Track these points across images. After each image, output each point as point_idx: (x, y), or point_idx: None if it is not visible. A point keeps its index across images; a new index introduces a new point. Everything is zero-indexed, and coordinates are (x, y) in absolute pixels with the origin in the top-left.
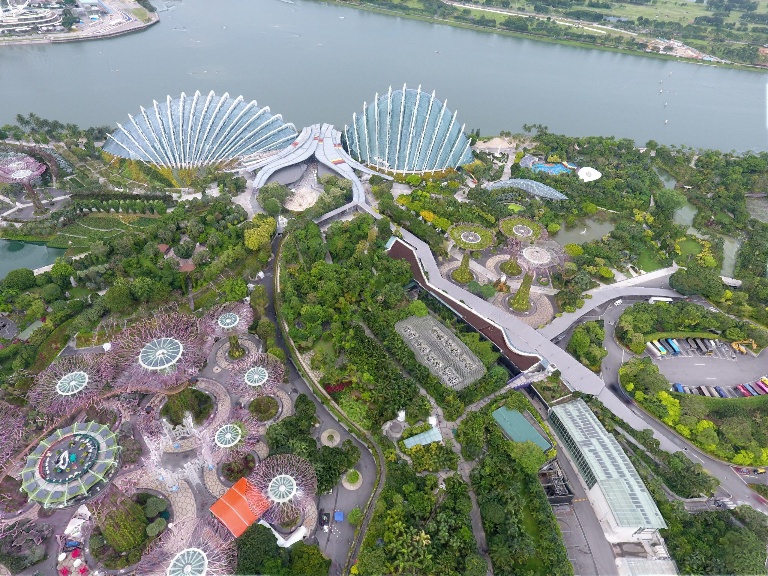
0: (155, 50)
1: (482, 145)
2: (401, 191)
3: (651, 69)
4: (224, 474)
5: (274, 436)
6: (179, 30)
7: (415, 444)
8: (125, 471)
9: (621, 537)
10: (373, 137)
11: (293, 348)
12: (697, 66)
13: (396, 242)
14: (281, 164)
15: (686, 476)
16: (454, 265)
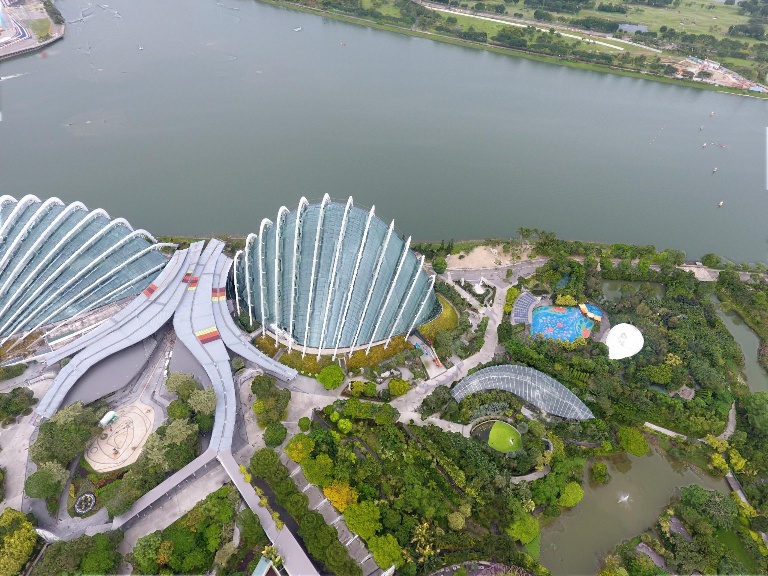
0: (36, 85)
1: (456, 264)
2: (308, 398)
3: (681, 100)
4: None
5: None
6: (82, 52)
7: None
8: None
9: None
10: (272, 285)
11: None
12: (741, 97)
13: (268, 575)
14: (107, 347)
15: None
16: None
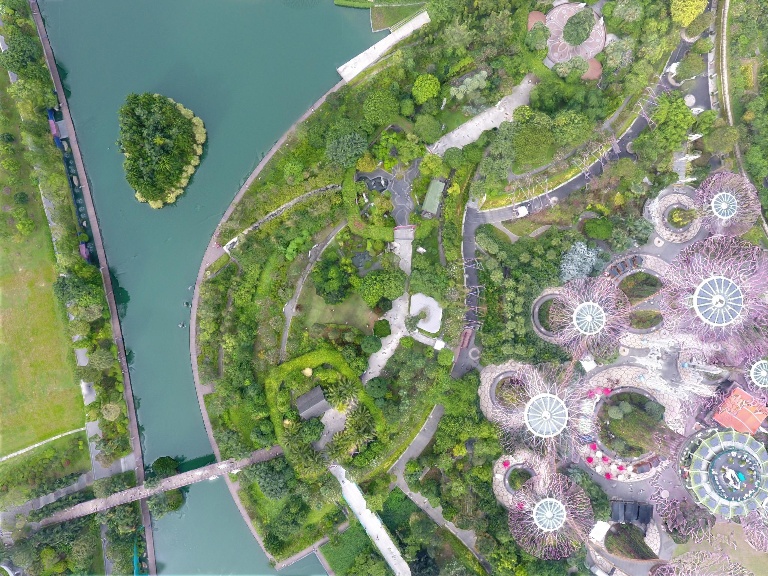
0: None
1: None
2: None
3: None
4: (700, 372)
5: None
6: None
7: None
8: (601, 368)
9: None
10: None
11: (761, 218)
12: None
13: None
14: None
15: None
16: None
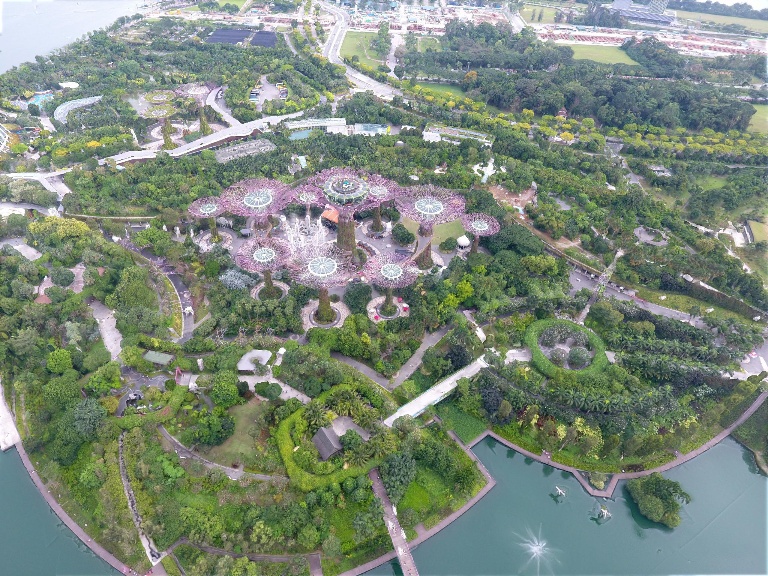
0: None
1: None
2: None
3: None
4: None
5: (297, 206)
6: None
7: (305, 164)
8: None
9: (346, 133)
10: None
11: None
12: None
13: None
14: None
15: (327, 107)
16: (155, 149)
